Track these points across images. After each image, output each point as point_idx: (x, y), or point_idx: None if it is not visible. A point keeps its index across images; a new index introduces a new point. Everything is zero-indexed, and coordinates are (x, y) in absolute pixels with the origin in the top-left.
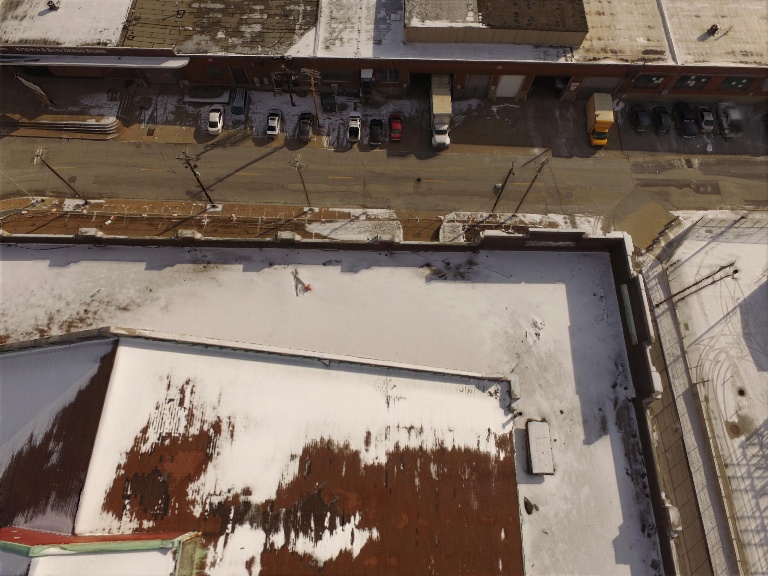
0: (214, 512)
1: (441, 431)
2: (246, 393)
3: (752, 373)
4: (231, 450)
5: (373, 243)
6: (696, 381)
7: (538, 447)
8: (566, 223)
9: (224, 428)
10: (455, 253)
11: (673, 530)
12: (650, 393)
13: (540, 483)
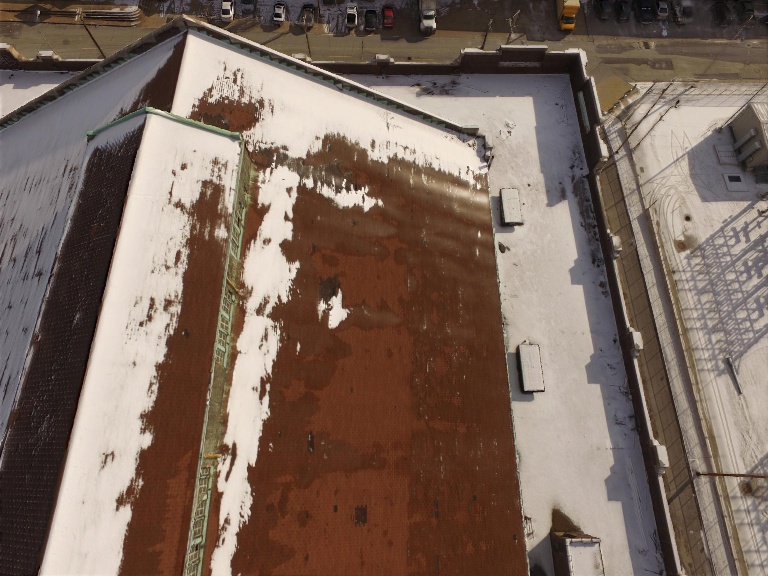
0: (262, 153)
1: (430, 157)
2: (281, 89)
3: (697, 204)
4: (272, 120)
5: (372, 64)
6: None
7: (509, 205)
8: None
9: (266, 105)
10: (441, 76)
11: (615, 250)
12: (599, 159)
13: (511, 232)
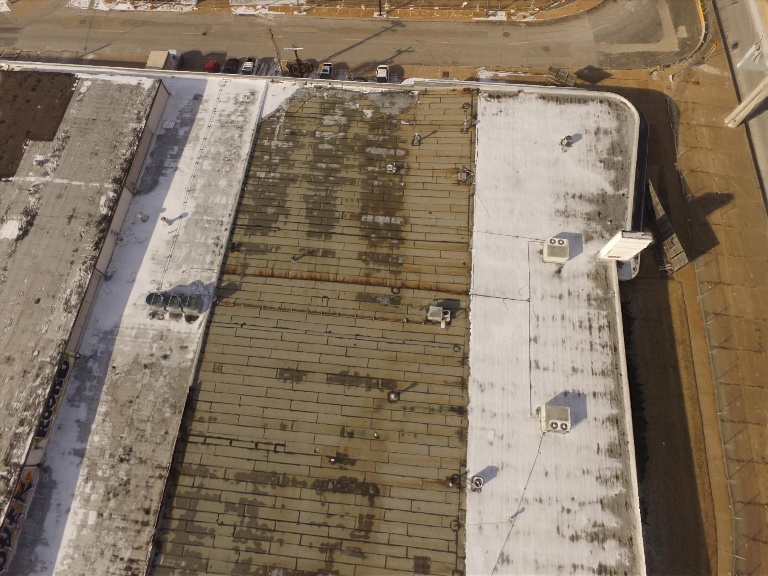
0: None
1: None
2: None
3: None
4: None
5: None
6: None
7: None
8: (98, 3)
9: None
10: None
11: None
12: None
13: None
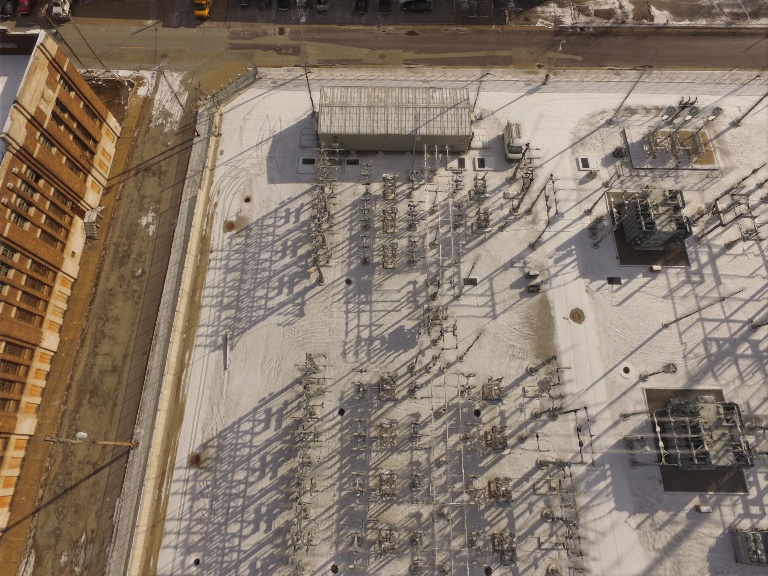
0: None
1: None
2: None
3: (262, 185)
4: None
5: None
6: (212, 192)
7: None
8: (152, 77)
9: None
10: None
11: None
12: None
13: None
